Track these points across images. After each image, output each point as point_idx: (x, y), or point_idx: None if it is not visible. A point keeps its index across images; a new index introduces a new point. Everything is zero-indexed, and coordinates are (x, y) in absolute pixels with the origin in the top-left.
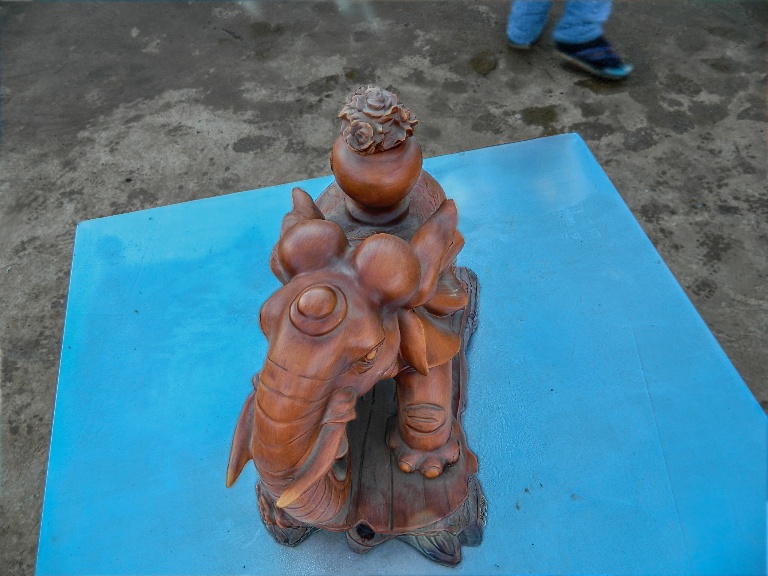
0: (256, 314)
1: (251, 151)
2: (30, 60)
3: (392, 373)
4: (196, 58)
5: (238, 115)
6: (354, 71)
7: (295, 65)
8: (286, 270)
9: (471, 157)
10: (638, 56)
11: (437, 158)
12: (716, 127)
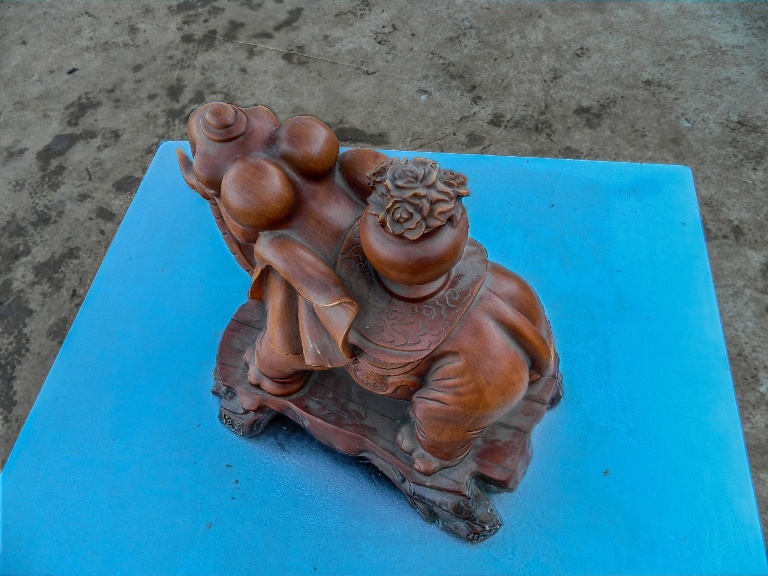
0: None
1: None
2: None
3: None
4: None
5: None
6: None
7: None
8: None
9: None
10: None
11: None
12: None
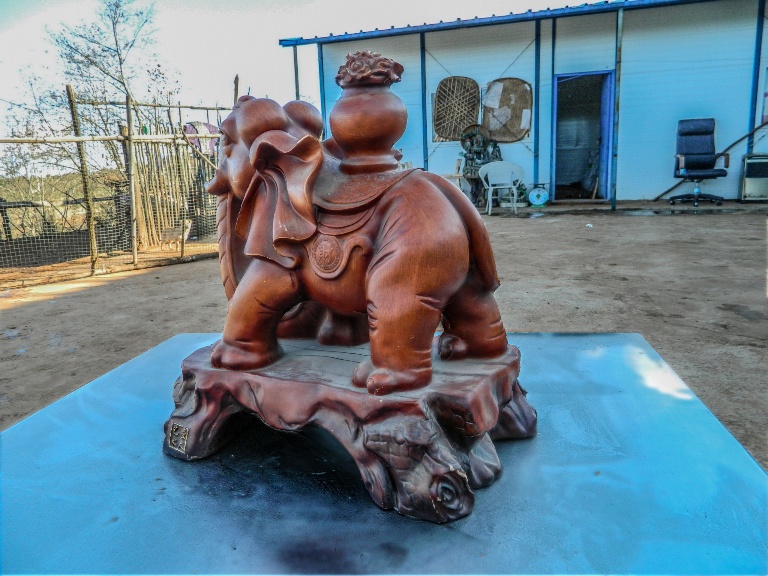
0: None
1: None
2: None
3: None
4: None
5: None
6: None
7: None
8: None
9: None
10: None
11: None
12: None
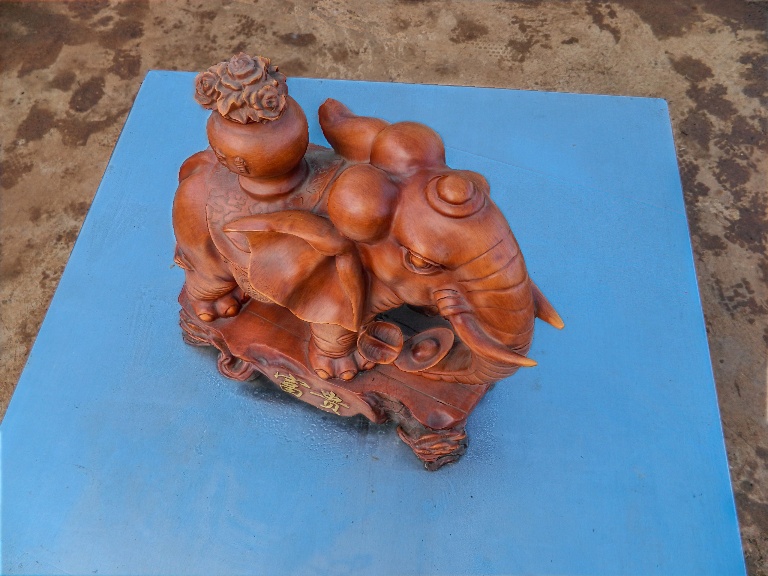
0: (204, 429)
1: None
2: None
3: None
4: None
5: None
6: None
7: None
8: (381, 225)
9: (120, 162)
10: (27, 14)
11: (100, 191)
12: (153, 10)
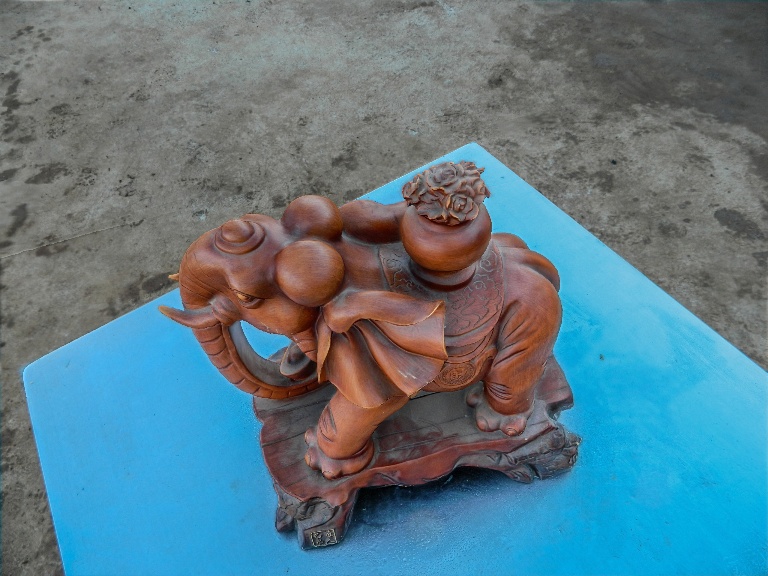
0: None
1: (727, 227)
2: (686, 29)
3: (307, 353)
4: None
5: (765, 192)
6: None
7: None
8: None
9: None
10: None
11: (753, 366)
12: None
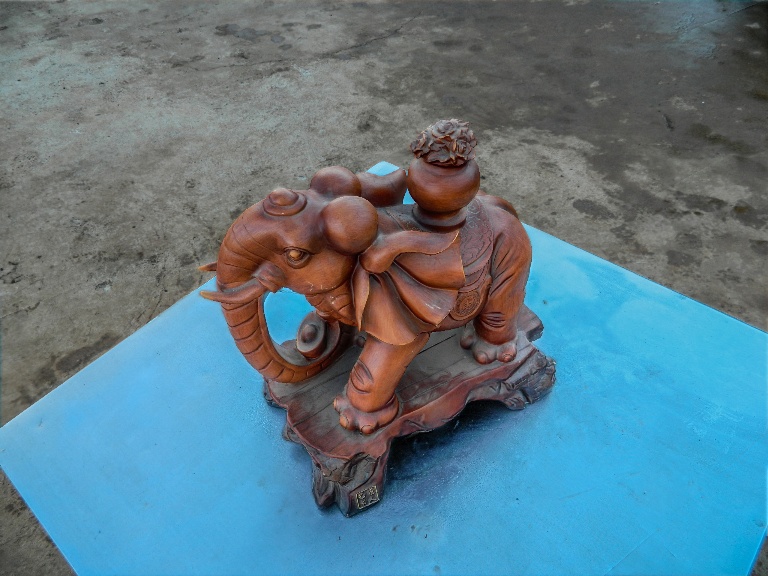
0: None
1: (585, 213)
2: (508, 69)
3: (341, 310)
4: (619, 125)
5: (605, 182)
6: (748, 209)
7: (696, 173)
8: None
9: (687, 305)
10: None
11: (655, 285)
12: None
